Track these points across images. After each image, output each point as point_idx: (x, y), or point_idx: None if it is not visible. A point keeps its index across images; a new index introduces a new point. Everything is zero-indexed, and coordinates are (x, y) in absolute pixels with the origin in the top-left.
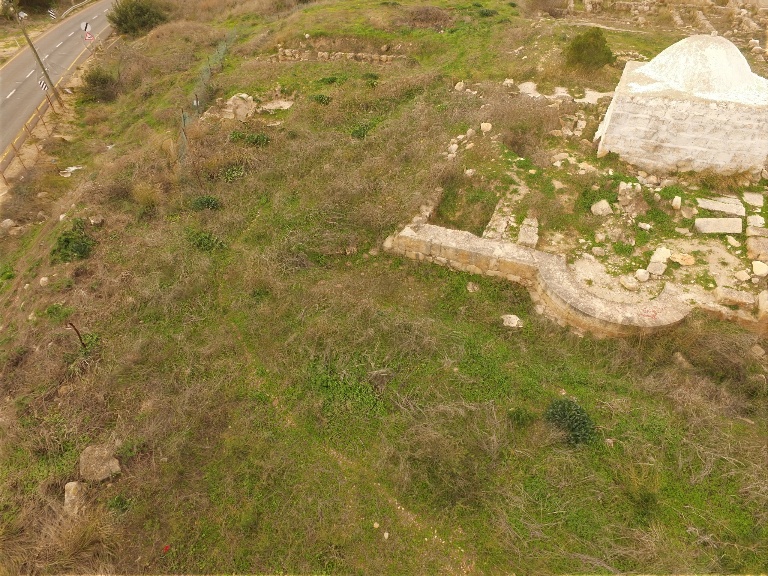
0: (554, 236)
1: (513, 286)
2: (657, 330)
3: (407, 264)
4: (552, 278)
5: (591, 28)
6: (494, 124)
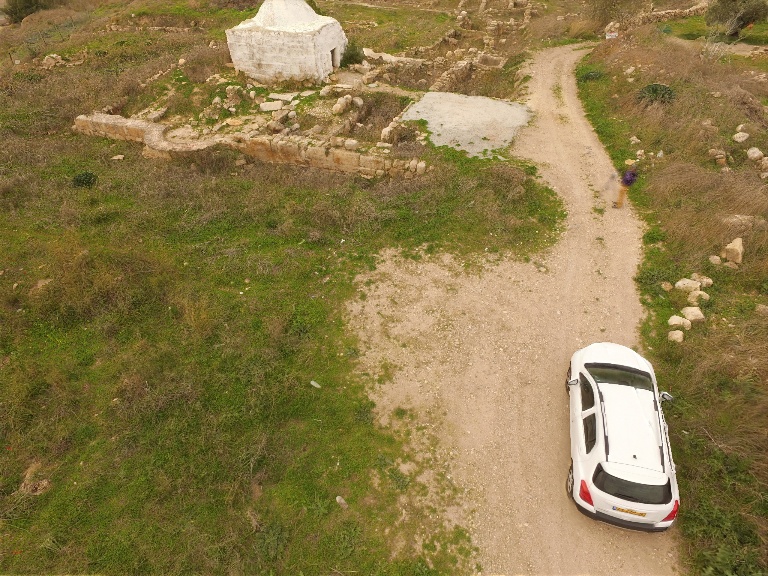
0: (175, 117)
1: (137, 144)
2: (189, 154)
3: (82, 137)
4: (149, 134)
5: (356, 6)
6: (189, 60)
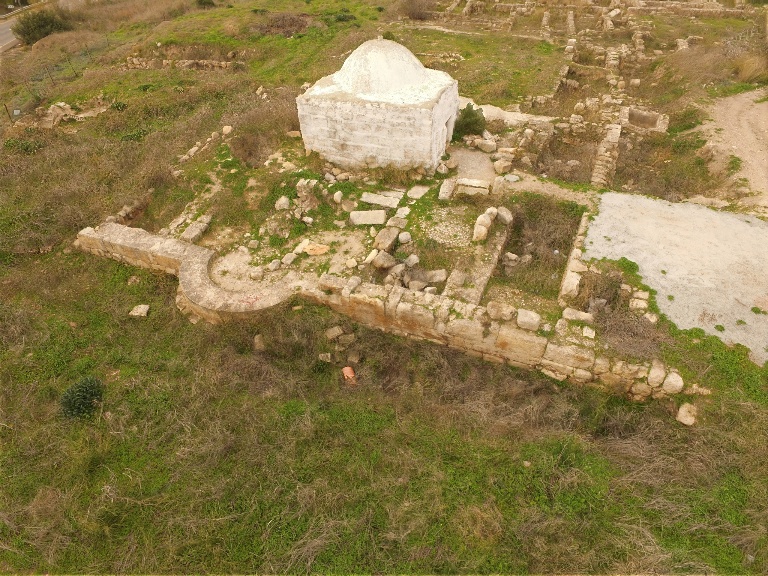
0: (223, 231)
1: (168, 278)
2: (251, 315)
3: (88, 261)
4: (187, 270)
5: (430, 31)
6: (236, 127)
